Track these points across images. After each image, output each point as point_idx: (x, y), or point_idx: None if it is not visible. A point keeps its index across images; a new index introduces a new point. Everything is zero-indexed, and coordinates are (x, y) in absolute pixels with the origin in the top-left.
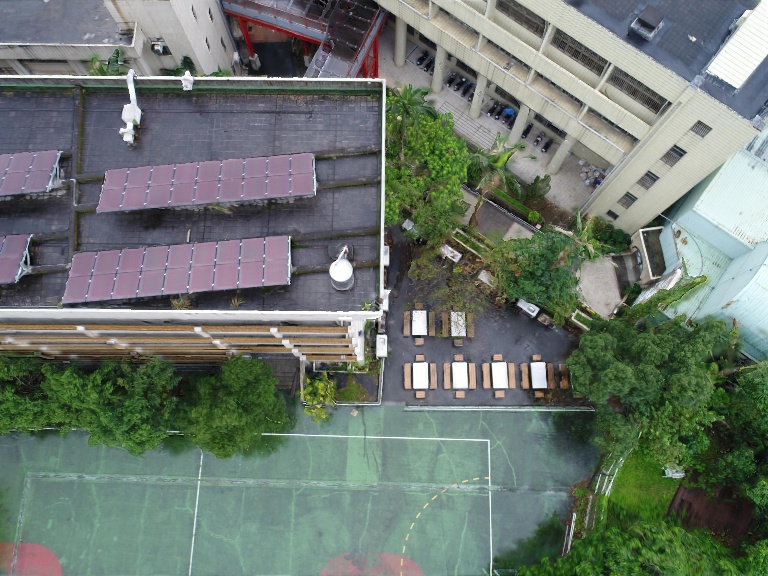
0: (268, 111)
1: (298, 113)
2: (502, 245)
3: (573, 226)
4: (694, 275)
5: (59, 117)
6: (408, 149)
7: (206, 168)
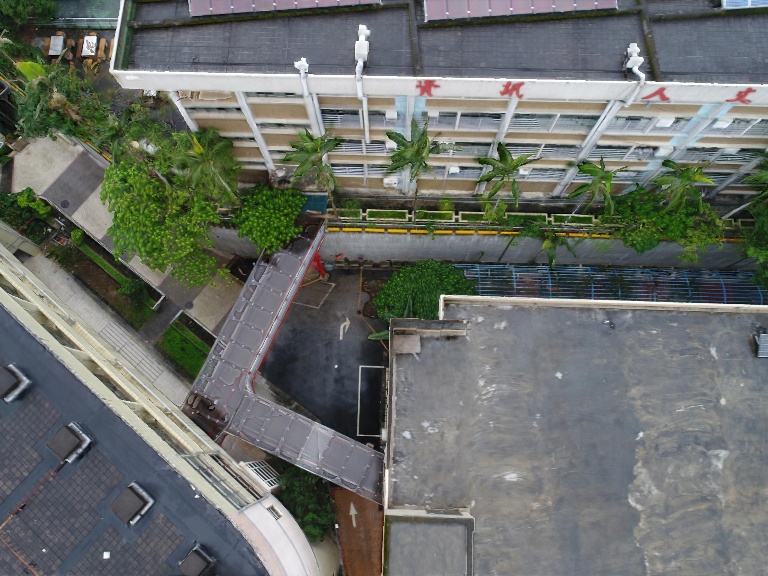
0: (235, 66)
1: (206, 63)
2: None
3: (43, 237)
4: None
5: (437, 61)
6: (154, 183)
7: (288, 0)
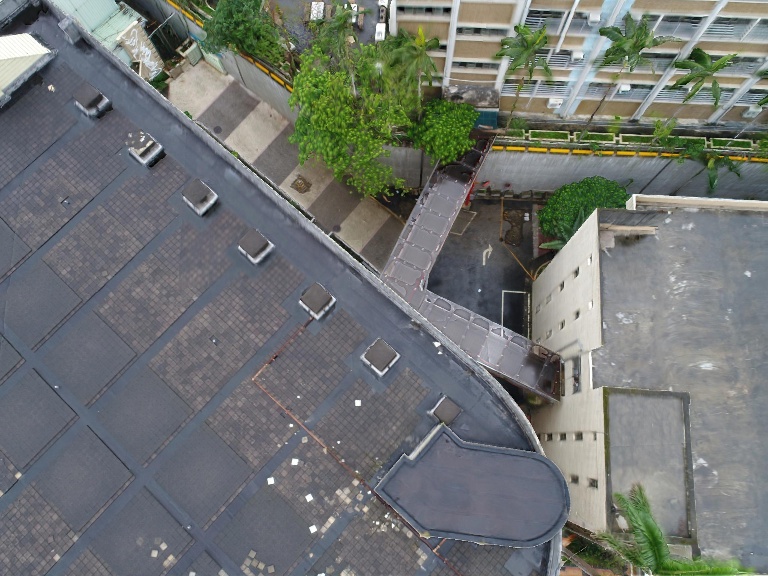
0: None
1: None
2: (270, 39)
3: None
4: (105, 43)
5: None
6: None
7: None
